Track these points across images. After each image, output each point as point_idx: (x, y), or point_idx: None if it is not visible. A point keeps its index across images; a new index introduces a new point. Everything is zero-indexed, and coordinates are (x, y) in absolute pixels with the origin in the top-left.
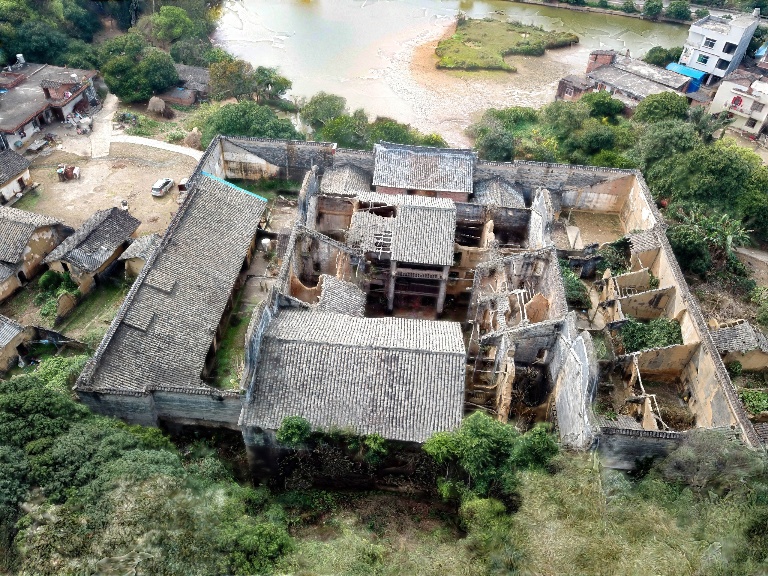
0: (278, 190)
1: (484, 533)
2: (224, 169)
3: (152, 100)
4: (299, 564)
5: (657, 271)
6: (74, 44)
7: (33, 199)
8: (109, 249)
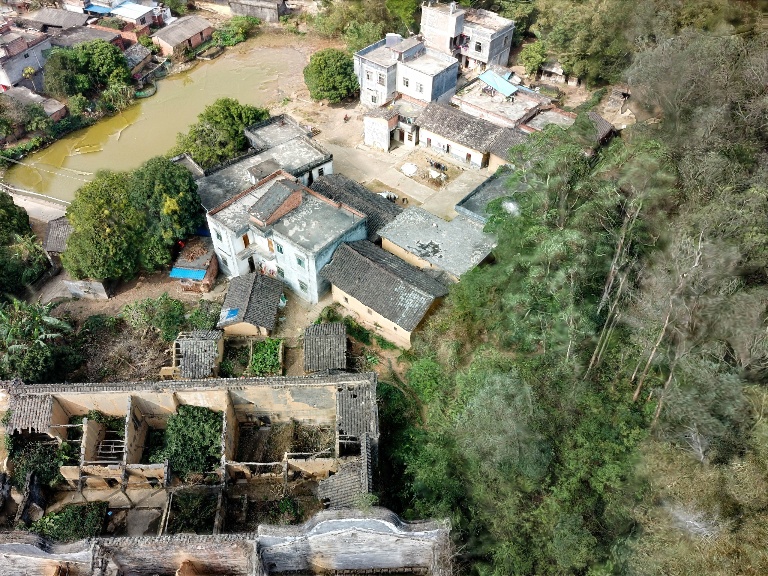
0: None
1: None
2: None
3: None
4: None
5: (80, 409)
6: None
7: None
8: None
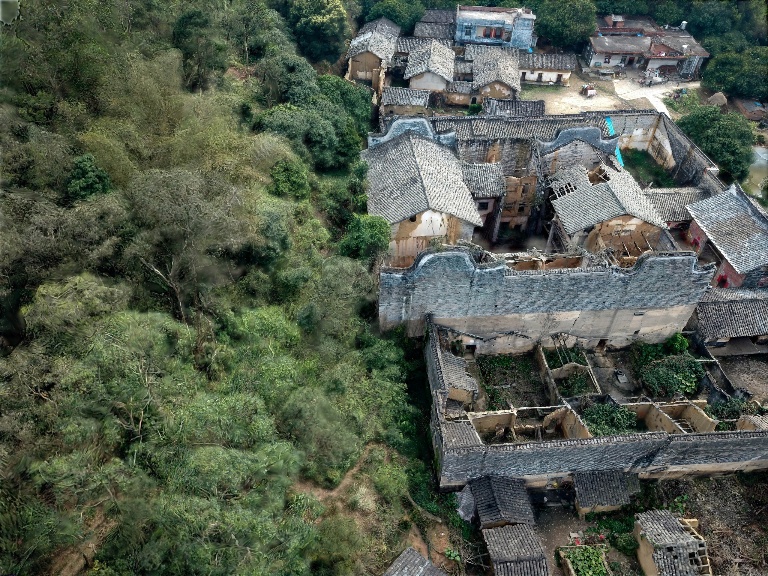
0: (656, 178)
1: (302, 229)
2: (650, 142)
3: (716, 94)
4: (292, 196)
5: None
6: (730, 34)
7: (553, 89)
8: (509, 114)
